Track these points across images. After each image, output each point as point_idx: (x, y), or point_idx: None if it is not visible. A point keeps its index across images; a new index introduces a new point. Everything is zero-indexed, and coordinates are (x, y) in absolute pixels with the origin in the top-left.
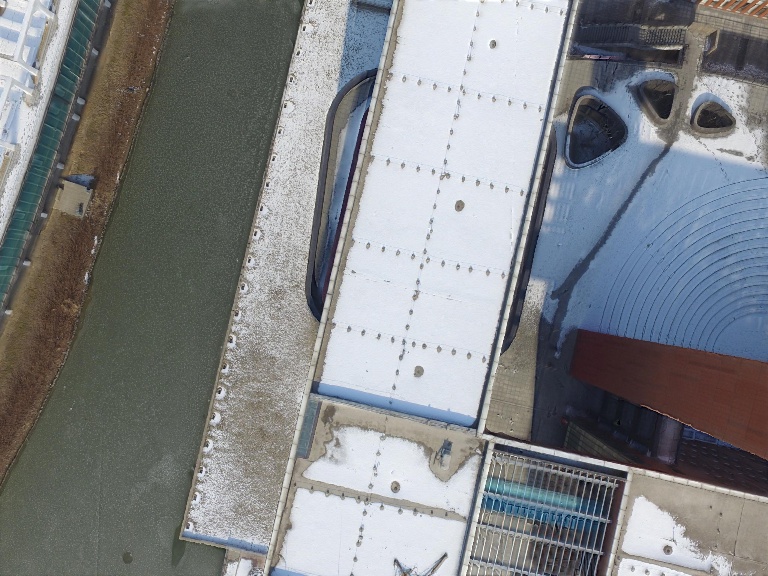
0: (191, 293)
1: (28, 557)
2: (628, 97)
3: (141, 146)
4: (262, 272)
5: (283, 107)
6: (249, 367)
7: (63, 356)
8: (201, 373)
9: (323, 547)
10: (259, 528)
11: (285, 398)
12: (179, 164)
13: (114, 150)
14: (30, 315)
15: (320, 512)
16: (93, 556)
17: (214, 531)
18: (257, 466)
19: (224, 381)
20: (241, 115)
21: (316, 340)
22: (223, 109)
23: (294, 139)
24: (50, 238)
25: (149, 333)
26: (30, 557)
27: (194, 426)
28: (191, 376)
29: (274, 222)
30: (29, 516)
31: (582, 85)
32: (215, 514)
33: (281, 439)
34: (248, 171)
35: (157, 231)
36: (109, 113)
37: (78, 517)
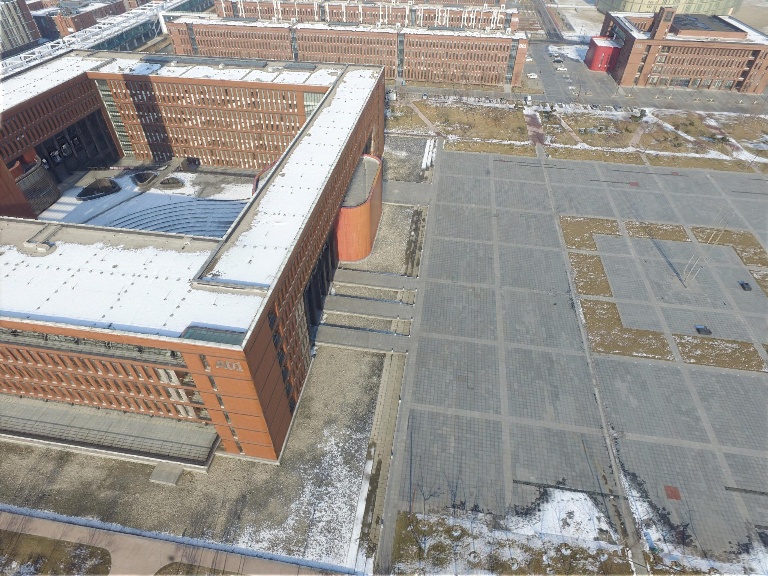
0: None
1: None
2: (129, 179)
3: None
4: None
5: None
6: None
7: None
8: None
9: None
10: None
11: None
12: None
13: None
14: None
15: None
16: None
17: None
18: None
19: None
20: None
21: None
22: None
23: None
24: None
25: None
26: None
27: None
28: None
29: None
30: None
31: (105, 177)
32: None
33: None
34: None
35: None
36: None
37: None
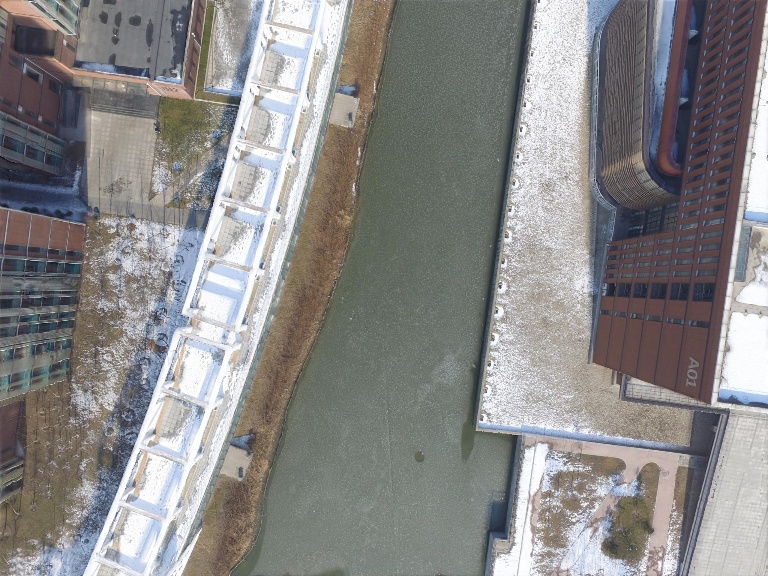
0: (456, 196)
1: (324, 465)
2: None
3: (394, 55)
4: (531, 166)
5: (537, 2)
6: (527, 260)
7: (339, 268)
8: (473, 273)
9: (761, 365)
10: (550, 413)
11: (564, 287)
12: (433, 70)
13: (371, 60)
14: (309, 228)
15: (755, 333)
16: (386, 458)
17: (507, 420)
18: (543, 355)
19: (504, 276)
20: (489, 16)
21: (744, 168)
22: (471, 11)
23: (551, 33)
24: (322, 150)
25: (419, 238)
26: (326, 465)
27: (471, 325)
28: (464, 277)
29: (538, 117)
30: (321, 426)
31: None
32: (507, 404)
33: (564, 327)
34: (501, 71)
35: (418, 138)
36: (364, 23)
37: (368, 422)
